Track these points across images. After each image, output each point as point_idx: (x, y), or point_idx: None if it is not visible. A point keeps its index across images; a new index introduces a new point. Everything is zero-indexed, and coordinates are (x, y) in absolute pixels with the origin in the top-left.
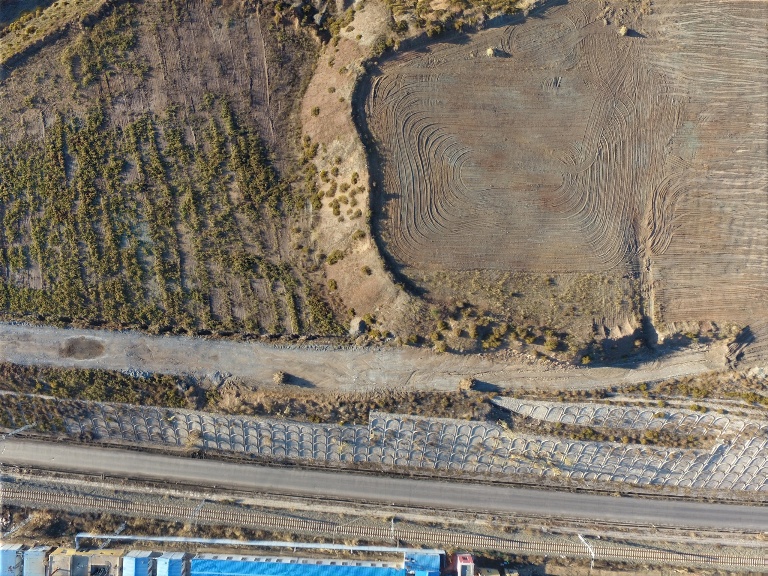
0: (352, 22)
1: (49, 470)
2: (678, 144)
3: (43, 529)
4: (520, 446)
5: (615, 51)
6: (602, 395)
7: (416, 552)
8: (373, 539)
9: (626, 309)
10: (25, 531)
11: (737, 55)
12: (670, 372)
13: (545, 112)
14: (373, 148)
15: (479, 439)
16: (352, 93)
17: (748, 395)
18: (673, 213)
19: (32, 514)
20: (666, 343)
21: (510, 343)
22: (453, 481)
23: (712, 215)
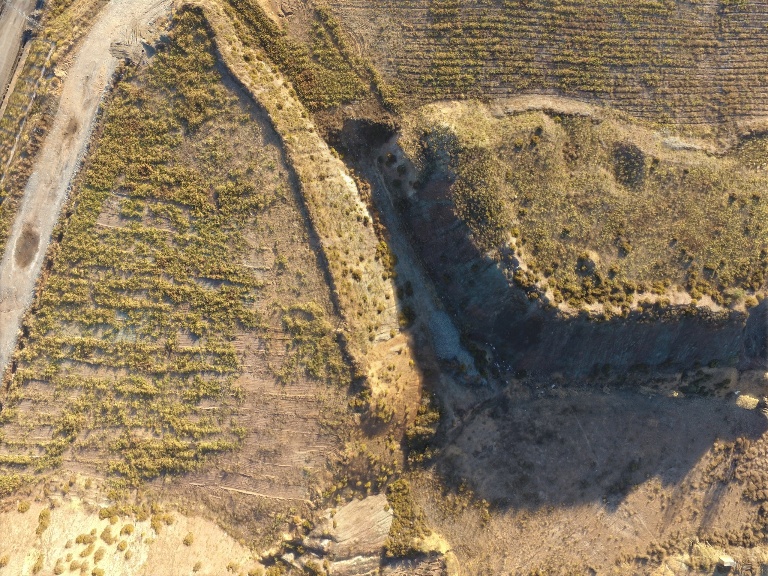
0: None
1: None
2: None
3: None
4: None
5: None
6: None
7: None
8: None
9: None
10: None
11: None
12: None
13: None
14: None
15: None
16: None
17: None
18: None
19: None
20: None
21: None
22: None
23: None
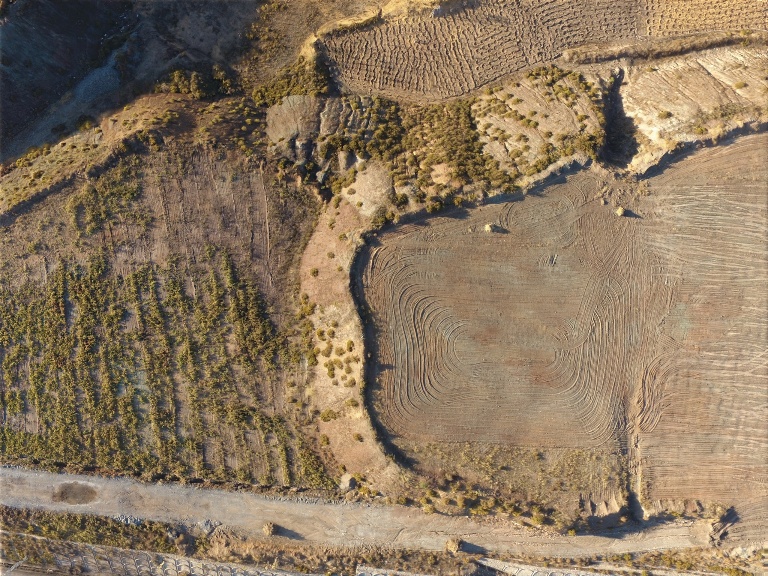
0: (354, 184)
1: None
2: (670, 325)
3: None
4: None
5: (611, 230)
6: (587, 563)
7: None
8: None
9: (613, 485)
10: None
11: (731, 239)
12: (655, 544)
13: (540, 288)
14: (369, 319)
15: None
16: (350, 265)
17: (731, 570)
18: (663, 392)
19: None
20: None
21: (497, 513)
22: None
23: (701, 395)
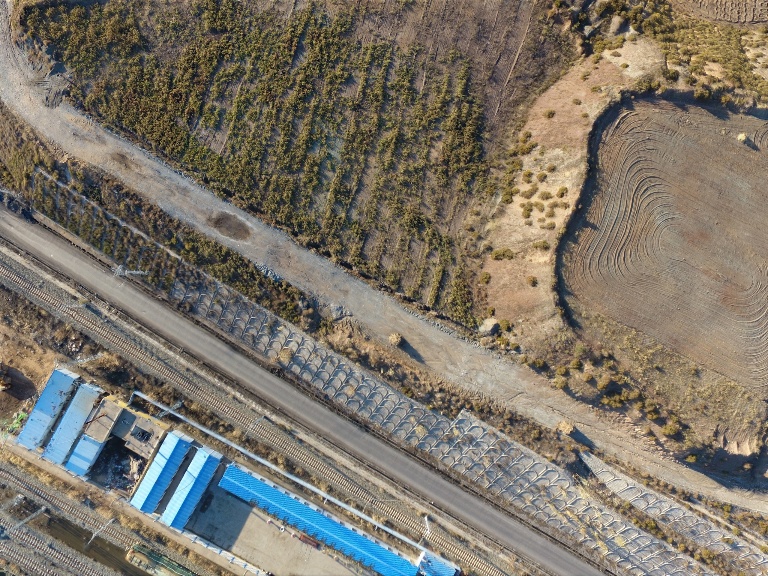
0: (620, 49)
1: (135, 320)
2: None
3: (106, 372)
4: (580, 506)
5: None
6: (686, 497)
7: (435, 557)
8: (400, 526)
9: (752, 430)
10: (89, 366)
11: None
12: (759, 506)
13: (764, 216)
14: (594, 173)
15: (546, 482)
16: (600, 114)
17: None
18: None
19: (102, 353)
20: None
21: (630, 410)
22: (497, 508)
23: None
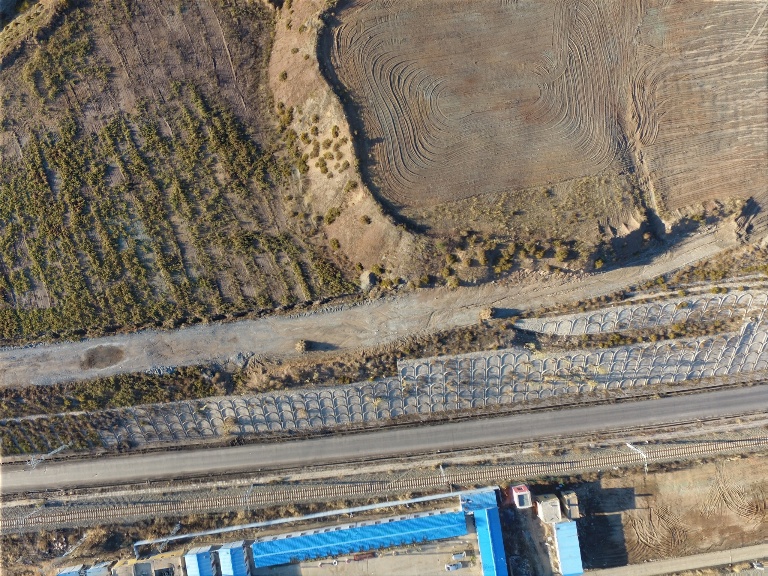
0: None
1: (94, 487)
2: (646, 33)
3: (100, 545)
4: (551, 366)
5: None
6: (622, 297)
7: (471, 493)
8: (426, 489)
9: (628, 205)
10: (83, 551)
11: None
12: (684, 260)
13: (509, 28)
14: (347, 98)
15: (510, 368)
16: (316, 48)
17: (765, 267)
18: (655, 102)
19: (86, 533)
20: (674, 232)
21: (521, 263)
22: (493, 416)
23: (694, 96)
